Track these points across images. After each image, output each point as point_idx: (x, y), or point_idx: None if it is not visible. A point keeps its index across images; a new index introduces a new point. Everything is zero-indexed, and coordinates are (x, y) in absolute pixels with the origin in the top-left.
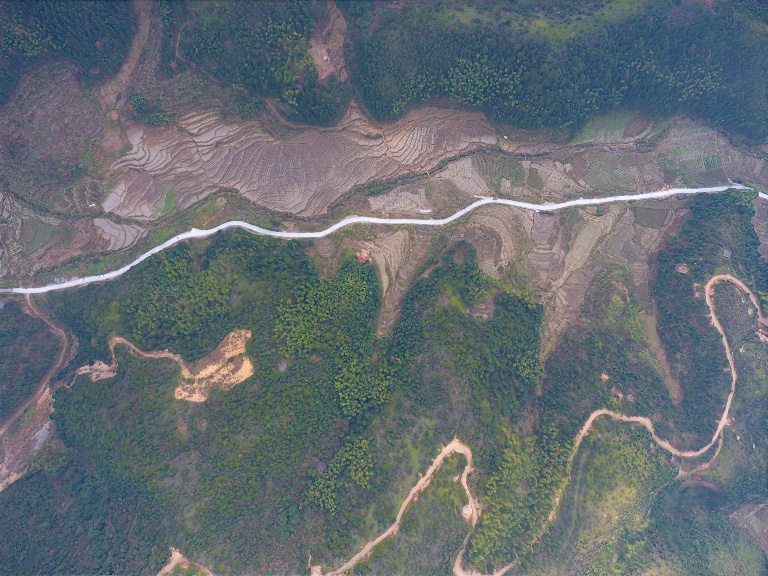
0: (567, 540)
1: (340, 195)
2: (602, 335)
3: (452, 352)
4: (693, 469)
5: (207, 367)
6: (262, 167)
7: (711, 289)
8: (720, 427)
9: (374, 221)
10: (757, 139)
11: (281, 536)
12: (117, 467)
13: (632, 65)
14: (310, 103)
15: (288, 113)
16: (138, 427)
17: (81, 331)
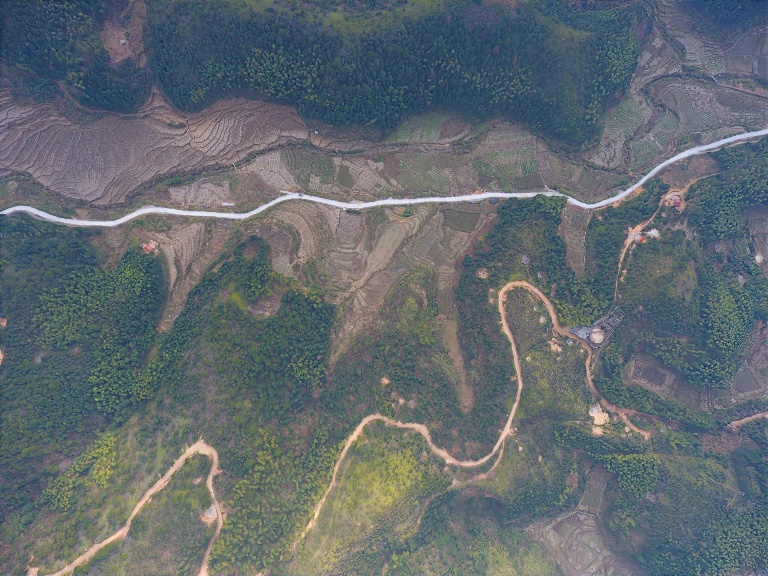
0: (319, 548)
1: (139, 184)
2: (391, 338)
3: (217, 349)
4: (469, 479)
5: None
6: (58, 151)
7: (504, 295)
8: (502, 437)
9: (172, 212)
10: (575, 146)
11: (7, 535)
12: None
13: (436, 64)
14: (100, 87)
15: (78, 96)
16: None
17: None
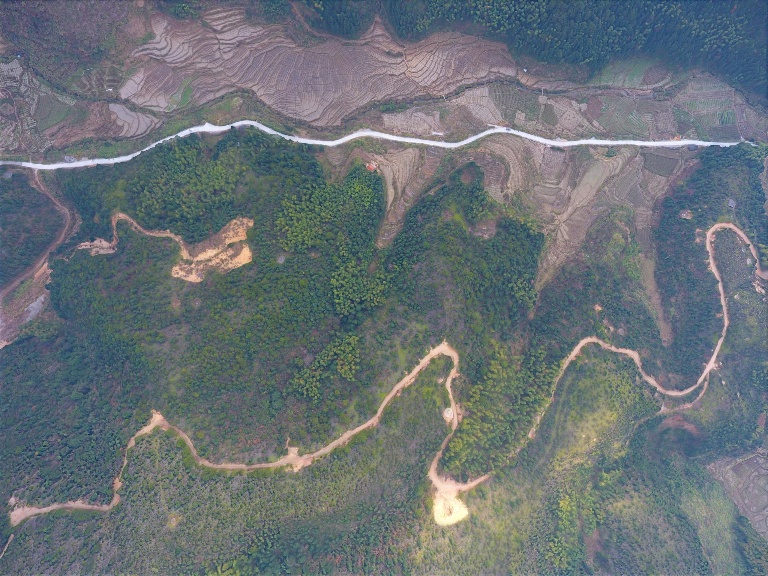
0: (544, 457)
1: (355, 109)
2: (600, 269)
3: (450, 262)
4: (676, 407)
5: (206, 251)
6: (281, 72)
7: (712, 235)
8: (707, 370)
9: (386, 137)
10: None
11: (262, 417)
12: (107, 330)
13: (658, 7)
14: (336, 10)
15: (313, 18)
16: (132, 296)
17: (85, 208)
